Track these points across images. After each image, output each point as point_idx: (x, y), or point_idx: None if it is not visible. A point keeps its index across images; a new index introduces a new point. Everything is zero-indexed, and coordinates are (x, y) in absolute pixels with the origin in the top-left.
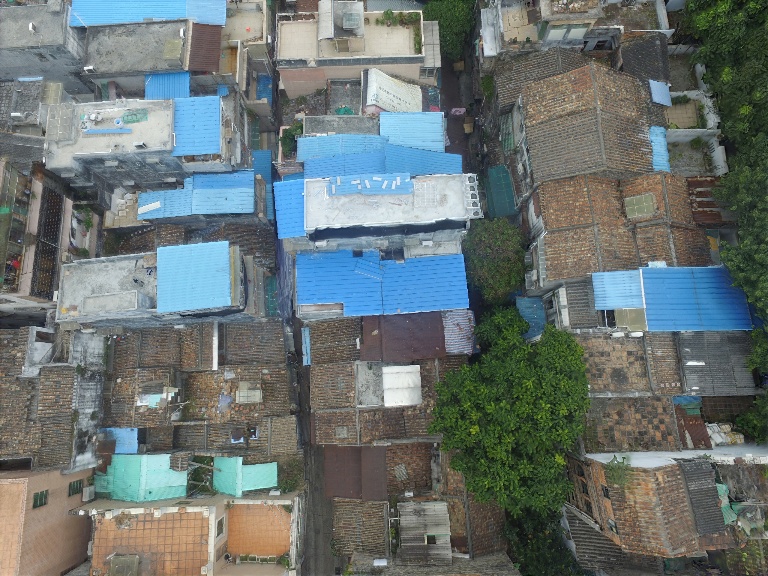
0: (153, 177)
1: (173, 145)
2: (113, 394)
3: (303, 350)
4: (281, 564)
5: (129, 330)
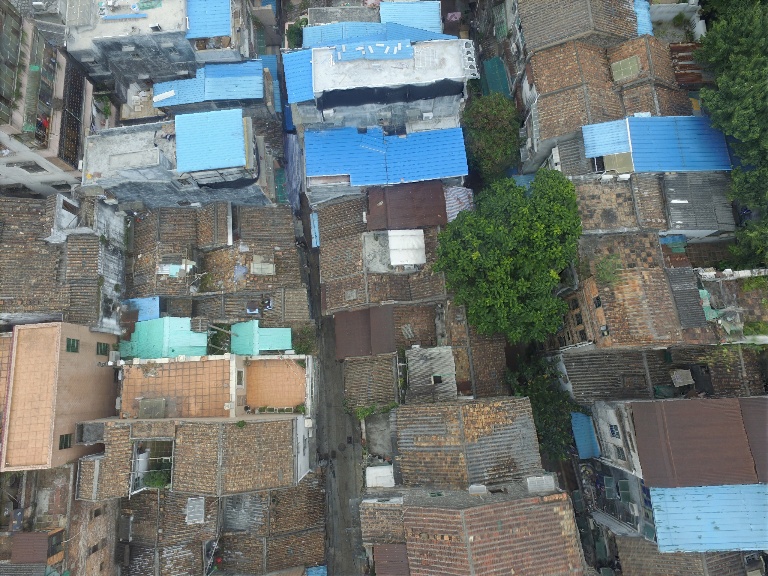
0: (167, 69)
1: (186, 28)
2: (134, 269)
3: (312, 234)
4: (297, 412)
5: (148, 209)
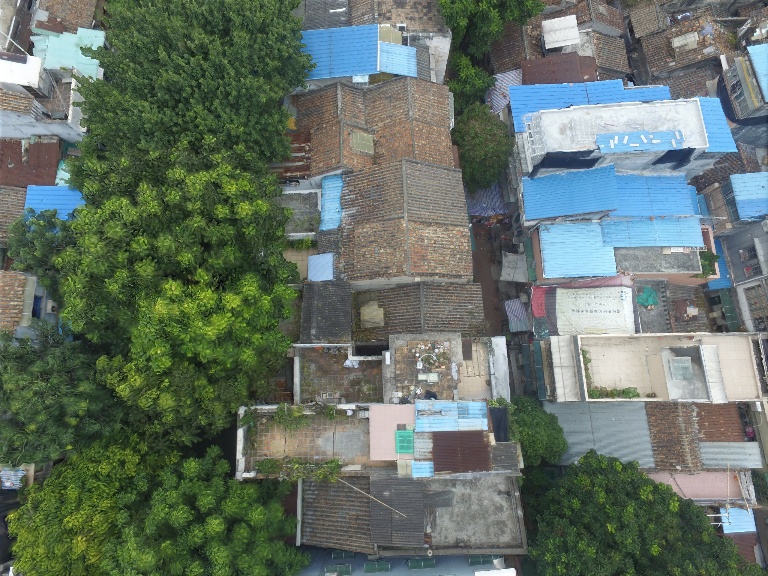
0: None
1: None
2: None
3: None
4: None
5: None
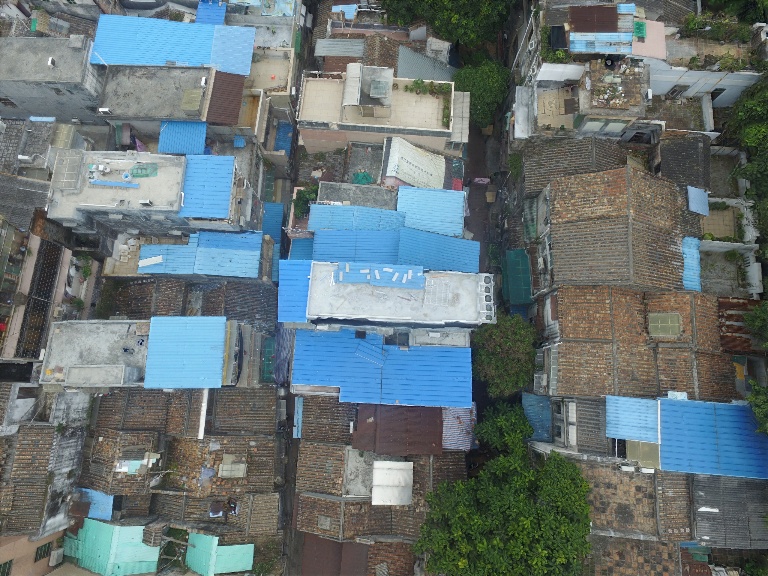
0: (158, 228)
1: (180, 205)
2: (93, 453)
3: (294, 421)
4: None
5: (116, 388)
